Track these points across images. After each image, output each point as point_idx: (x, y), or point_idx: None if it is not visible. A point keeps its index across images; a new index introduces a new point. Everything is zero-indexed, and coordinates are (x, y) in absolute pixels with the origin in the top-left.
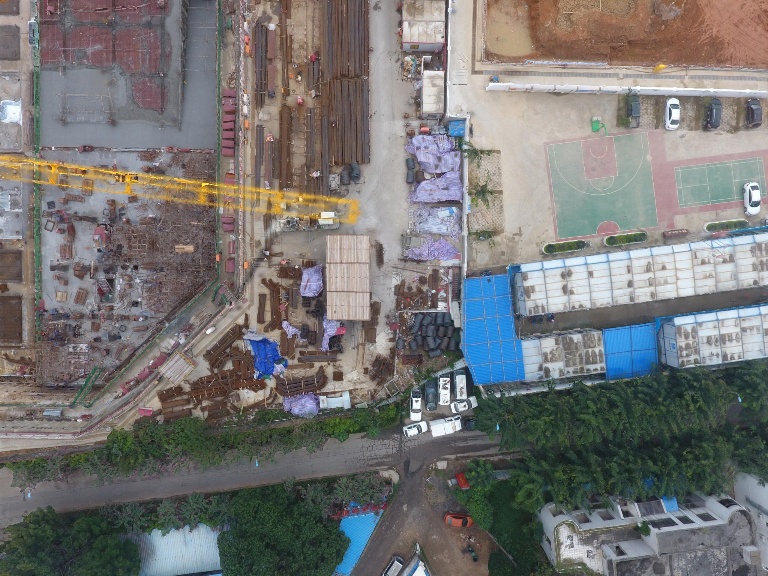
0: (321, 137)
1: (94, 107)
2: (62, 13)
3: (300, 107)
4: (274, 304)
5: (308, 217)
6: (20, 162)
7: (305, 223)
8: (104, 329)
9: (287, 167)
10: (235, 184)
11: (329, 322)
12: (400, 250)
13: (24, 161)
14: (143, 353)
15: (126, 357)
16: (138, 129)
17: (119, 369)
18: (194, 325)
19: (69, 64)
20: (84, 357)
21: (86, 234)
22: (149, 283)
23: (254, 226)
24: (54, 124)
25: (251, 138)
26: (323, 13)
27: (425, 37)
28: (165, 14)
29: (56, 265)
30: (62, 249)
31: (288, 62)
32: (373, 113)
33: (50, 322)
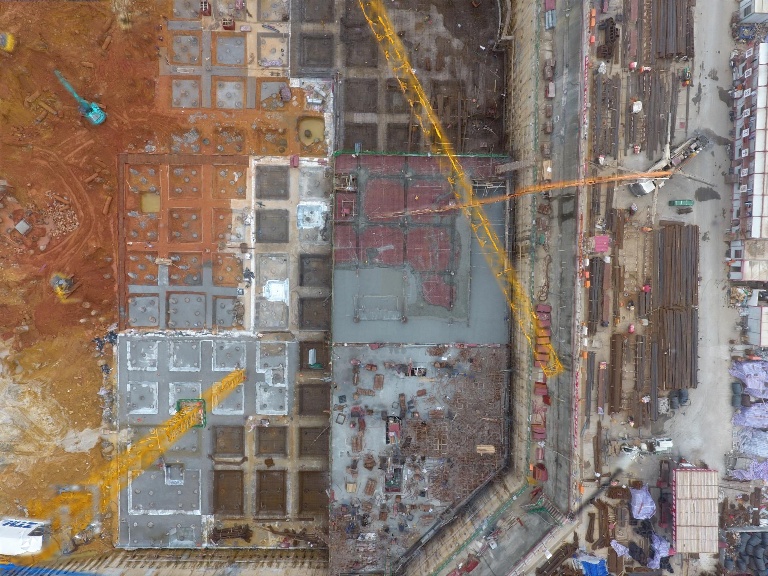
0: (650, 363)
1: (388, 306)
2: (356, 214)
3: (630, 334)
4: (602, 523)
5: (646, 445)
6: (286, 340)
7: (646, 453)
8: (391, 518)
9: (619, 393)
10: (554, 400)
11: (661, 543)
12: (723, 469)
13: (290, 339)
14: (452, 555)
15: (412, 544)
16: (427, 325)
17: (405, 556)
18: (501, 528)
19: (362, 263)
20: (372, 545)
21: (375, 426)
22: (435, 473)
23: (583, 448)
24: (346, 321)
25: (582, 364)
26: (654, 244)
27: (765, 275)
28: (455, 214)
29: (353, 461)
30: (354, 443)
31: (620, 291)
32: (699, 338)
33: (345, 515)
